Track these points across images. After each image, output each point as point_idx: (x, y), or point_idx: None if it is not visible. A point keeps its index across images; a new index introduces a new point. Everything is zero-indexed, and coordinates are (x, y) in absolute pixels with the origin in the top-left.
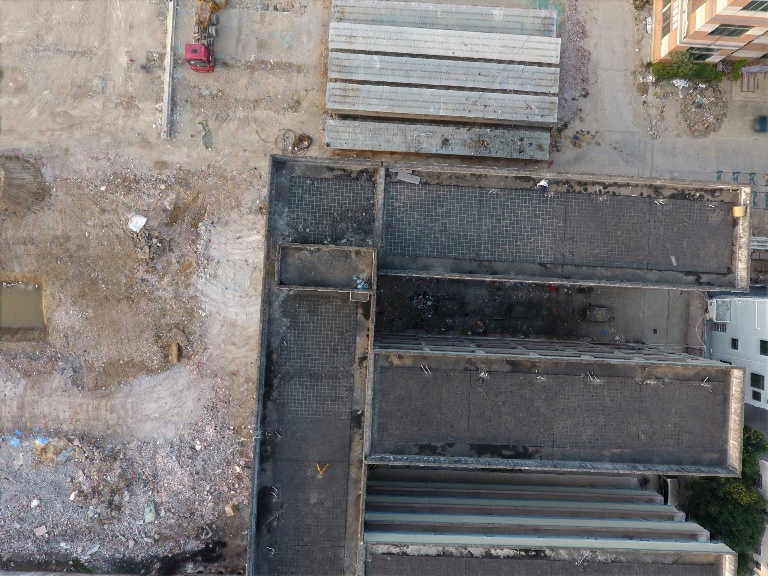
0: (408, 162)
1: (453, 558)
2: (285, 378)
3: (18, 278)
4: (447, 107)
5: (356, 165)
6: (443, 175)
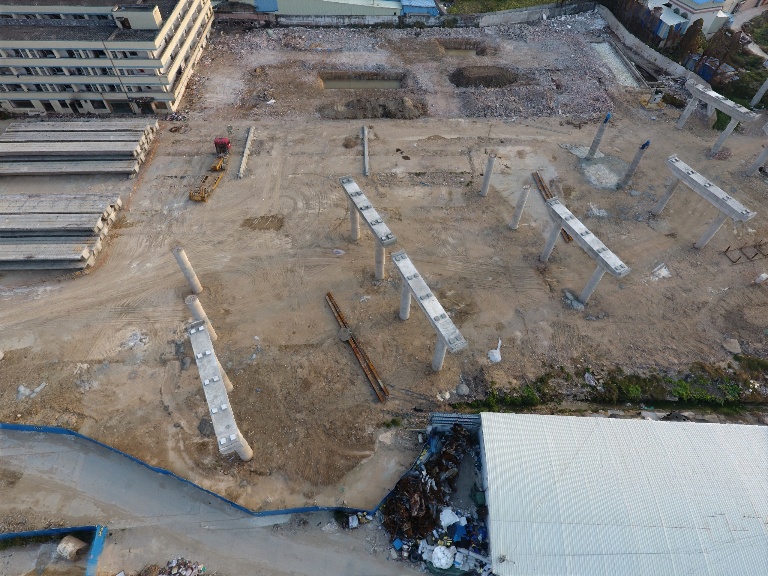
0: (90, 41)
1: None
2: (171, 7)
3: None
4: None
5: (118, 46)
6: None
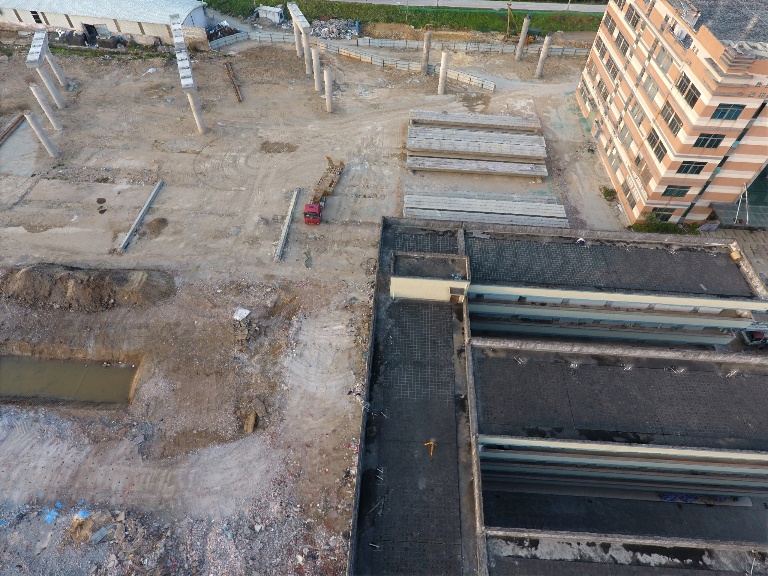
0: None
1: (594, 564)
2: (391, 365)
3: (121, 357)
4: None
5: (442, 228)
6: (506, 235)
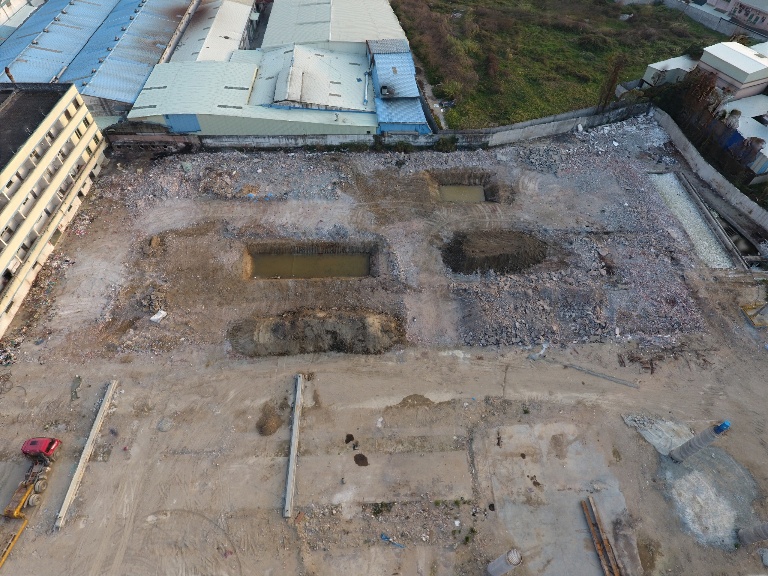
0: None
1: None
2: None
3: None
4: None
5: None
6: None
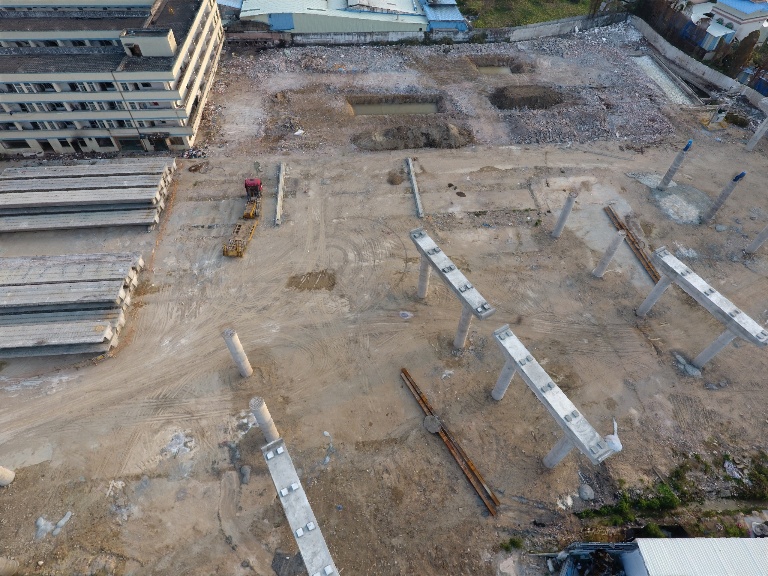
0: (97, 72)
1: None
2: None
3: None
4: (83, 168)
5: (129, 77)
6: None
